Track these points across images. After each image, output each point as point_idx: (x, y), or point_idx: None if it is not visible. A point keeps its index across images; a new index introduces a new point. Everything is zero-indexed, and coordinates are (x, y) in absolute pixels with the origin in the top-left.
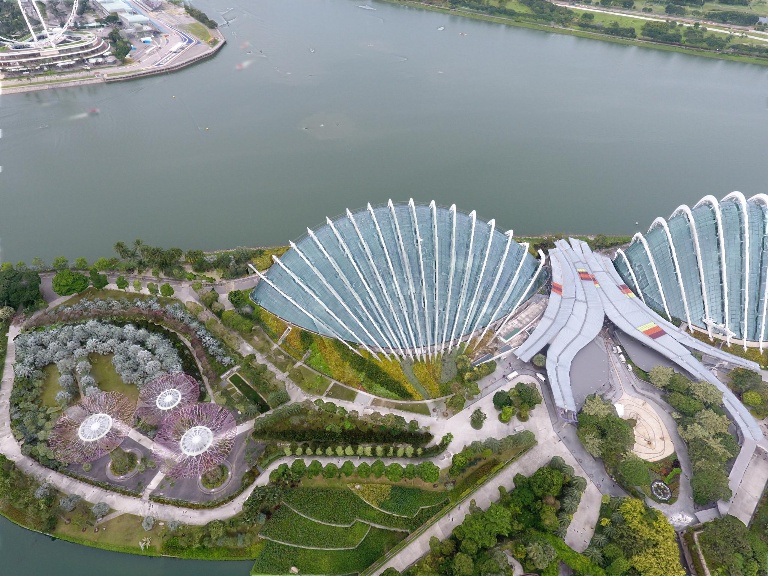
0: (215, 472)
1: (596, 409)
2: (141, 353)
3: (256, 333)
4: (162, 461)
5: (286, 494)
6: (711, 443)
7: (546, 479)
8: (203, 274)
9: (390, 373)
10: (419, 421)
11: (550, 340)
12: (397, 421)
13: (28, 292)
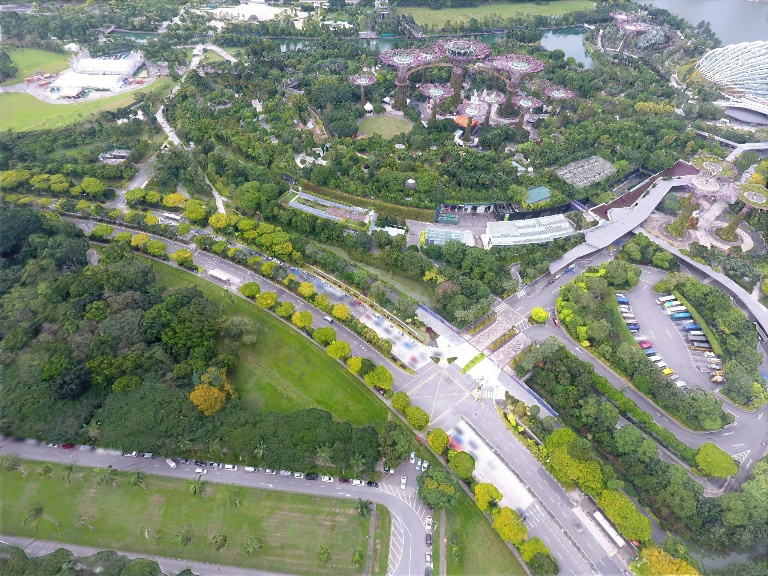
0: (621, 51)
1: (717, 104)
2: (653, 32)
3: (686, 59)
4: (620, 23)
5: (622, 65)
6: (724, 127)
7: (668, 86)
8: (709, 49)
9: (692, 75)
10: (673, 84)
11: (755, 105)
12: (668, 70)
13: (660, 15)
